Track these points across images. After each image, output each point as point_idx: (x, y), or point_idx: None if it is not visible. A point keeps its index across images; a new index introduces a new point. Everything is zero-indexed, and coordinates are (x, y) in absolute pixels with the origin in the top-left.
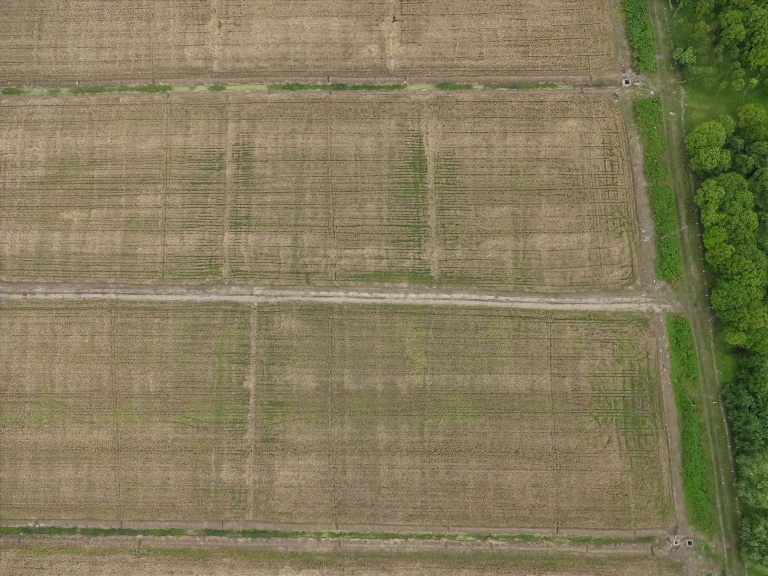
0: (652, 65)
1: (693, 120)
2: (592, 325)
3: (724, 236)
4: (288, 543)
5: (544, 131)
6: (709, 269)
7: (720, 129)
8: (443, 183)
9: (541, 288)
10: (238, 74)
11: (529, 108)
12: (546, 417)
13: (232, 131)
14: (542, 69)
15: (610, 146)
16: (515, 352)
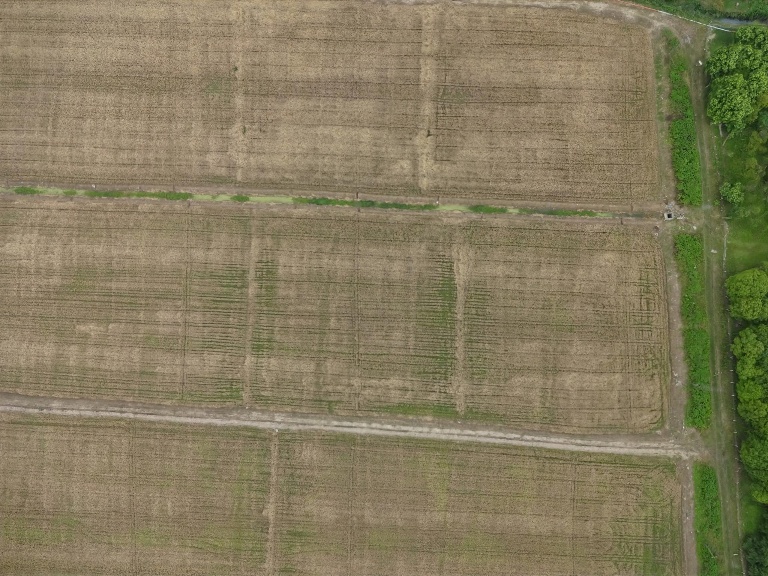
0: (697, 199)
1: (735, 259)
2: (617, 469)
3: (760, 394)
4: None
5: (580, 263)
6: (740, 421)
7: (764, 281)
8: (473, 314)
9: (568, 429)
10: (263, 185)
11: (566, 238)
12: (566, 560)
13: (256, 247)
14: (581, 196)
15: (647, 283)
16: (538, 493)
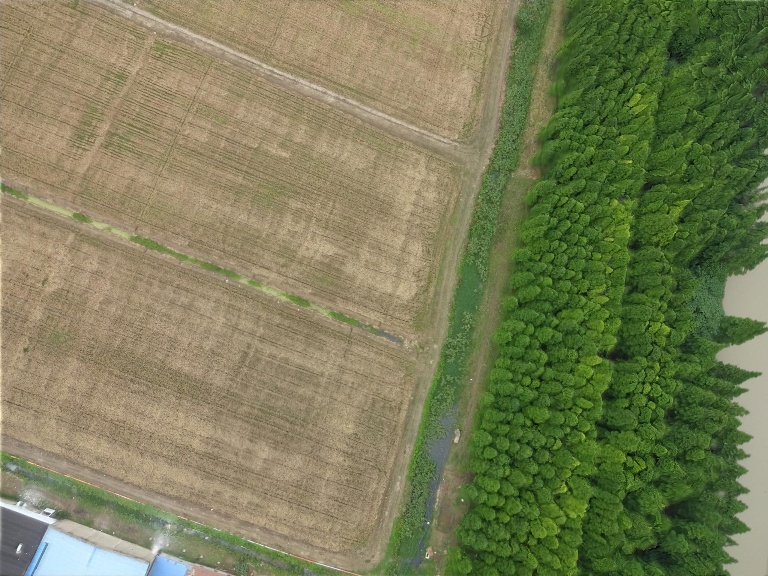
0: None
1: None
2: None
3: None
4: None
5: None
6: None
7: None
8: None
9: None
10: (50, 221)
11: None
12: None
13: (84, 165)
14: None
15: None
16: None
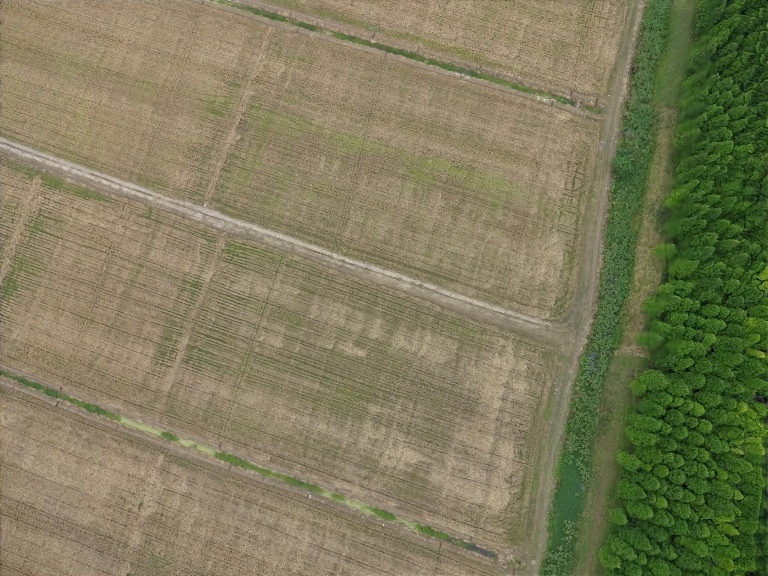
0: None
1: None
2: None
3: None
4: (247, 1)
5: None
6: None
7: None
8: None
9: None
10: (141, 443)
11: None
12: (2, 37)
13: (168, 382)
14: None
15: None
16: (2, 94)
